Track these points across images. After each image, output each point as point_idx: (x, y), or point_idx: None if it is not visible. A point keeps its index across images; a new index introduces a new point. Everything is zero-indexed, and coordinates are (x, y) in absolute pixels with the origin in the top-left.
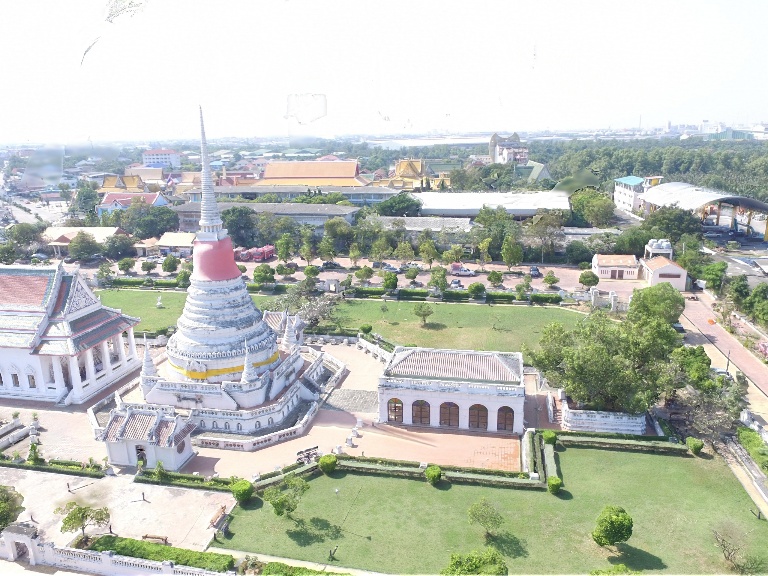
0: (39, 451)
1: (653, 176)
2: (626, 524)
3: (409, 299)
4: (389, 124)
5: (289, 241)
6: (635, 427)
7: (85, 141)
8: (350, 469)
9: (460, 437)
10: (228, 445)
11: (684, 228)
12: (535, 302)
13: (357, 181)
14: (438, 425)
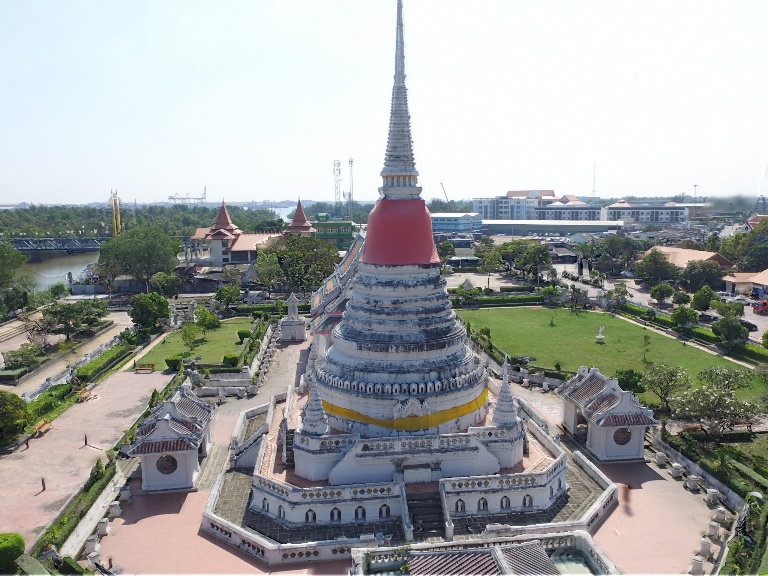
0: None
1: None
2: None
3: None
4: None
5: None
6: None
7: None
8: None
9: None
10: None
11: None
12: None
13: None
14: None
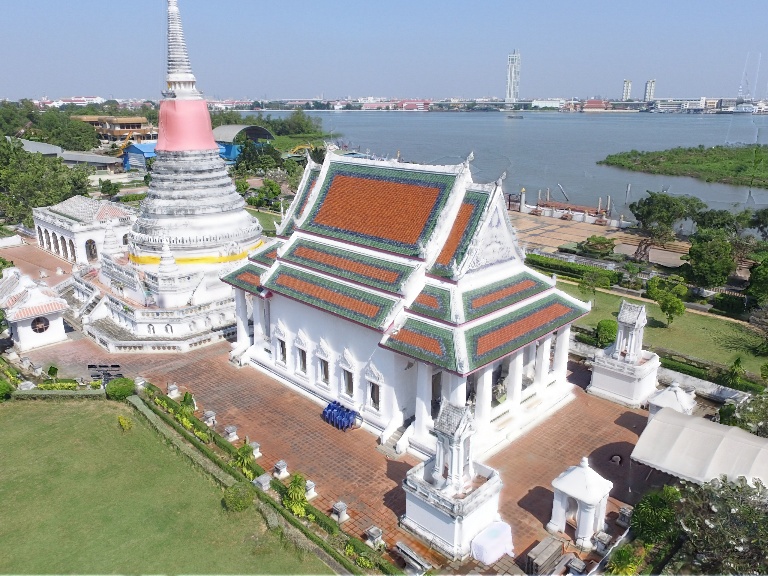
0: None
1: None
2: None
3: None
4: None
5: None
6: None
7: None
8: None
9: None
10: None
11: None
12: None
13: None
14: None
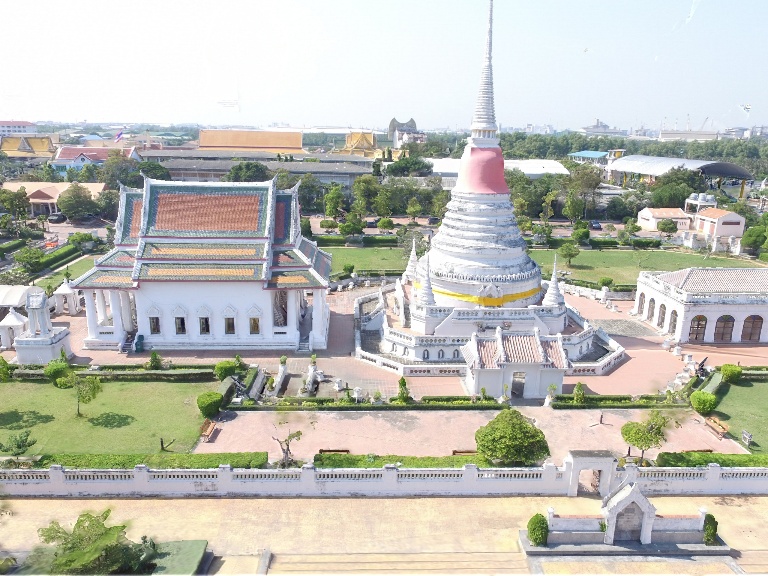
0: (365, 395)
1: (617, 149)
2: None
3: None
4: None
5: (341, 195)
6: None
7: None
8: (749, 377)
9: None
10: (576, 371)
11: (697, 187)
12: (637, 247)
13: (306, 152)
14: (739, 340)
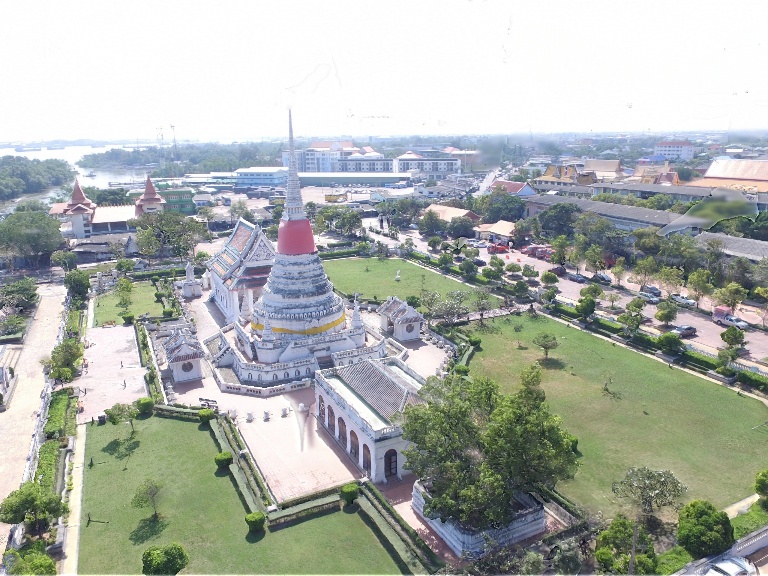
0: None
1: None
2: (153, 563)
3: (595, 331)
4: (385, 121)
5: (563, 244)
6: (457, 543)
7: (527, 132)
8: None
9: (332, 456)
10: None
11: None
12: (740, 383)
13: None
14: (338, 438)
